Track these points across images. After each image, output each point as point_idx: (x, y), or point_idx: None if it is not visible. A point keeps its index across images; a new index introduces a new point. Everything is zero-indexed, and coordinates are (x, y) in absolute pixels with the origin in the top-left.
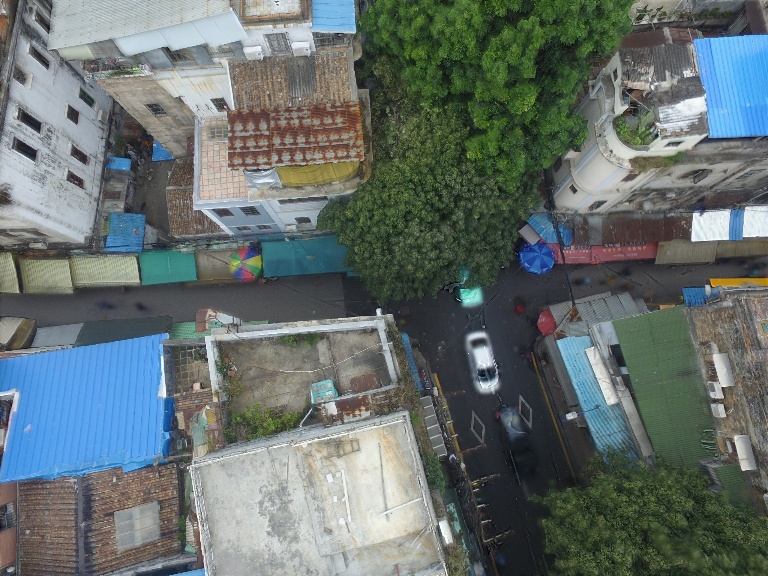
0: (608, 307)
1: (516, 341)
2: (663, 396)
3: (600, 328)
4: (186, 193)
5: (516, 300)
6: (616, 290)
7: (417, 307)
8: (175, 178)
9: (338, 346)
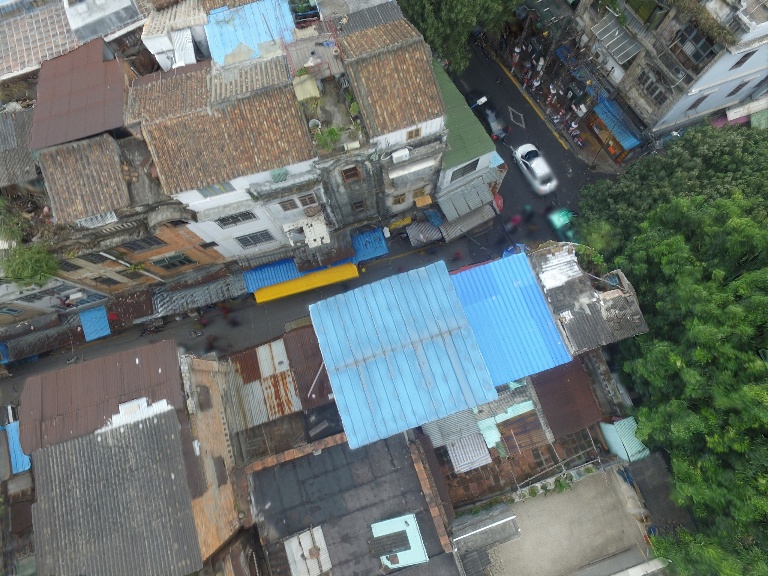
0: (467, 202)
1: (504, 194)
2: (444, 98)
3: (489, 160)
4: None
5: (515, 230)
6: (424, 264)
7: None
8: None
9: (766, 18)
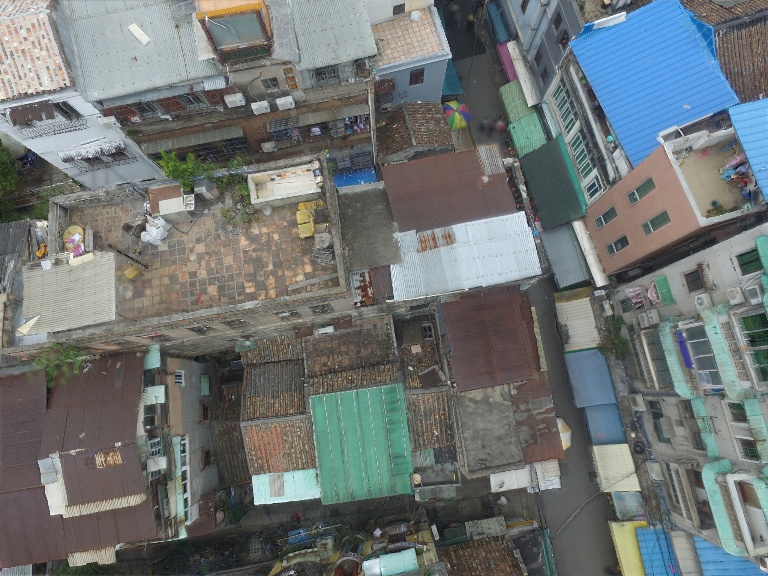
0: None
1: None
2: None
3: None
4: (415, 130)
5: None
6: None
7: (451, 8)
8: (401, 145)
9: None
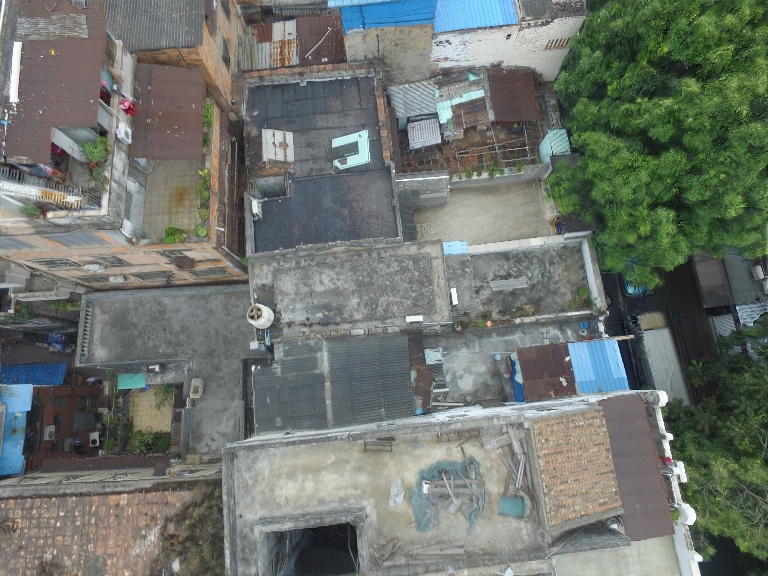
0: None
1: None
2: None
3: None
4: None
5: None
6: None
7: None
8: None
9: None
